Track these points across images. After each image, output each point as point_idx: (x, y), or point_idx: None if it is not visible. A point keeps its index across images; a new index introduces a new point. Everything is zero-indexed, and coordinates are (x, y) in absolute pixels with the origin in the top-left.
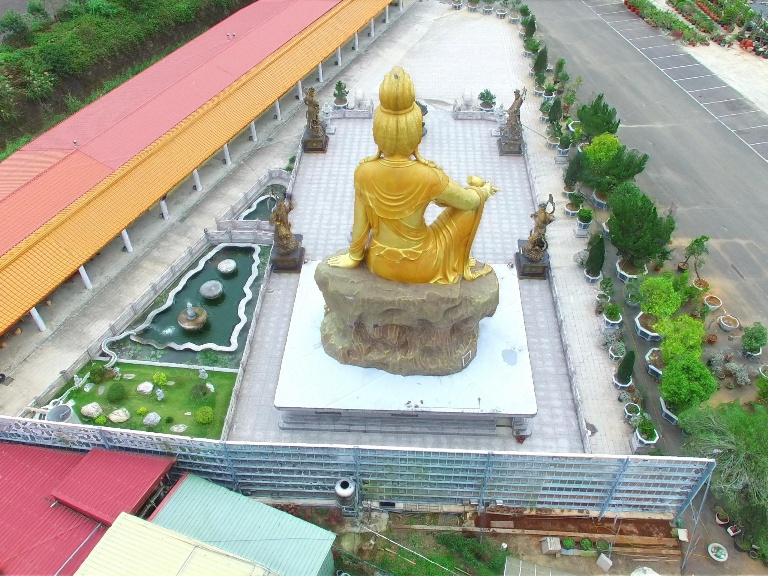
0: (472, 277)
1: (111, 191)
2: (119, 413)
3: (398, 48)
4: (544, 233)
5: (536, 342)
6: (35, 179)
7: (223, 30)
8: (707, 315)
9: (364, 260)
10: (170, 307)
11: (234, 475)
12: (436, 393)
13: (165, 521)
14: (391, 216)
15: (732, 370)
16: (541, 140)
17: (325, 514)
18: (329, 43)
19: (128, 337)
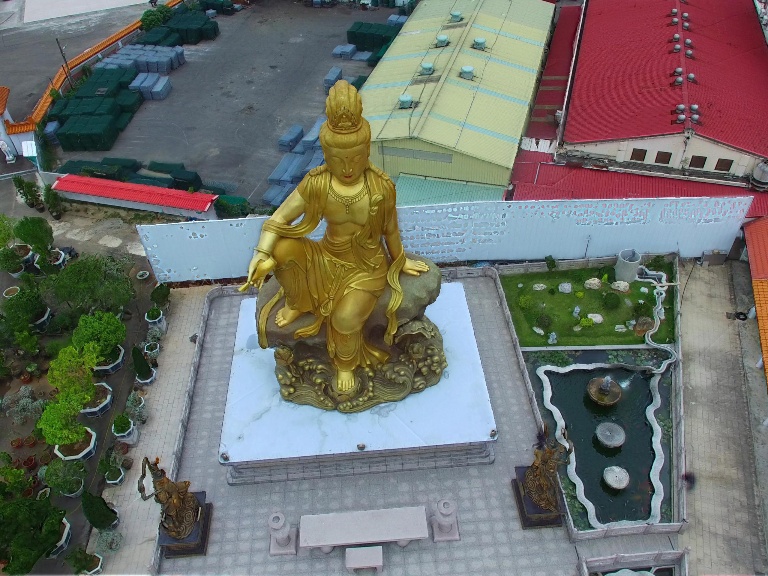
0: None
1: None
2: (594, 281)
3: None
4: None
5: (218, 412)
6: None
7: None
8: None
9: None
10: None
11: None
12: None
13: (495, 197)
14: None
15: None
16: None
17: None
18: None
19: None
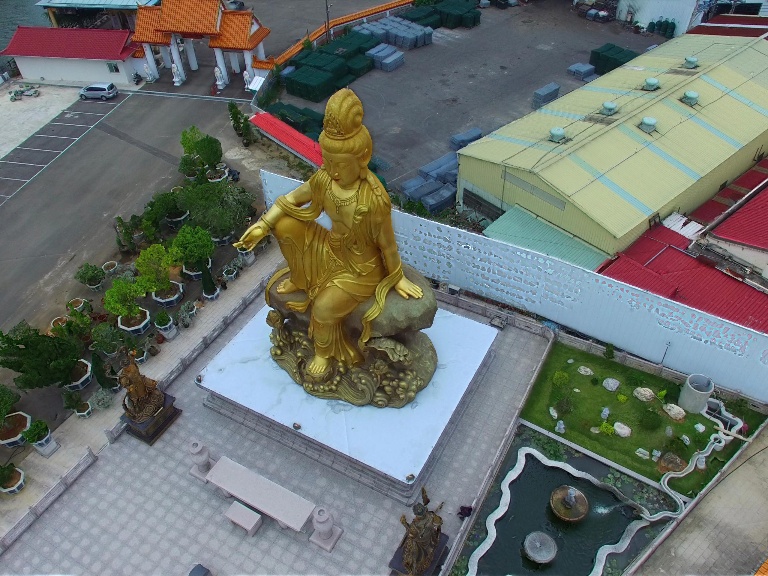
0: None
1: None
2: (644, 391)
3: None
4: None
5: None
6: None
7: None
8: None
9: None
10: None
11: None
12: None
13: (592, 262)
14: None
15: None
16: None
17: (479, 296)
18: None
19: None
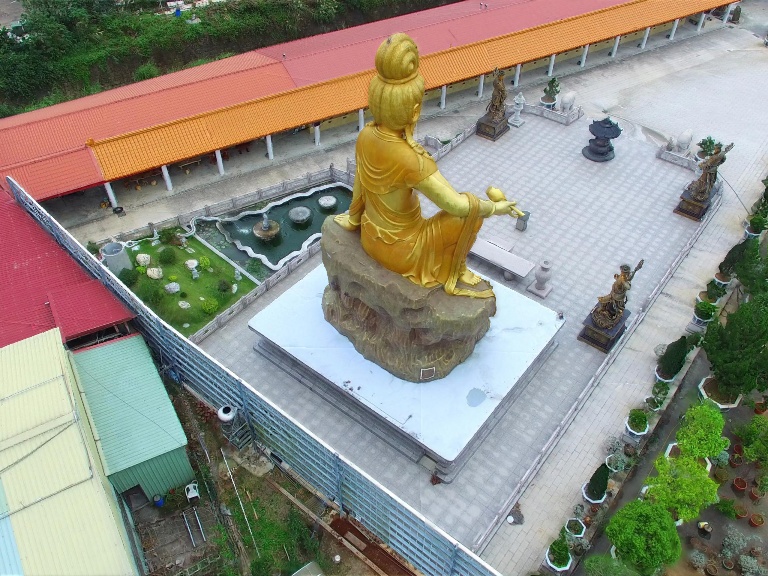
0: (453, 291)
1: (273, 101)
2: (154, 270)
3: (660, 67)
4: (619, 300)
5: (537, 405)
6: (235, 73)
7: (488, 0)
8: (767, 490)
9: (360, 227)
10: (262, 214)
11: (171, 355)
12: (378, 388)
13: (94, 356)
14: (370, 188)
15: (744, 566)
16: (742, 215)
17: None
18: (574, 38)
19: (215, 222)
